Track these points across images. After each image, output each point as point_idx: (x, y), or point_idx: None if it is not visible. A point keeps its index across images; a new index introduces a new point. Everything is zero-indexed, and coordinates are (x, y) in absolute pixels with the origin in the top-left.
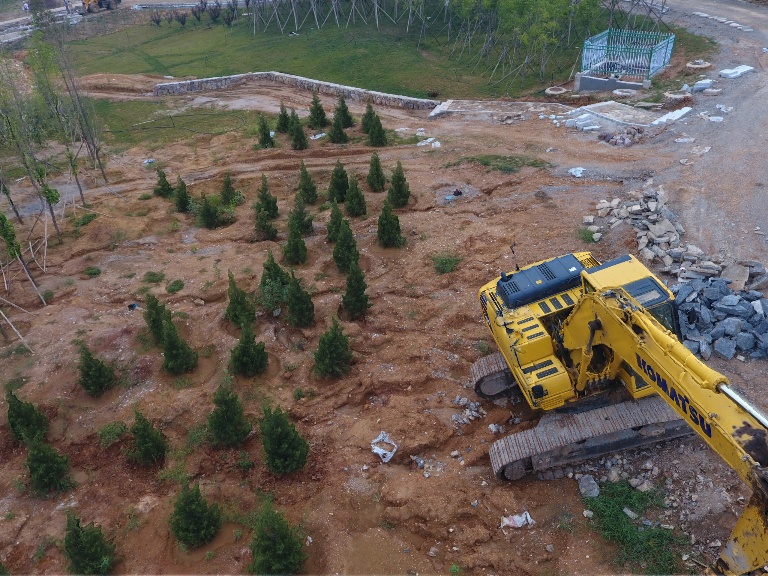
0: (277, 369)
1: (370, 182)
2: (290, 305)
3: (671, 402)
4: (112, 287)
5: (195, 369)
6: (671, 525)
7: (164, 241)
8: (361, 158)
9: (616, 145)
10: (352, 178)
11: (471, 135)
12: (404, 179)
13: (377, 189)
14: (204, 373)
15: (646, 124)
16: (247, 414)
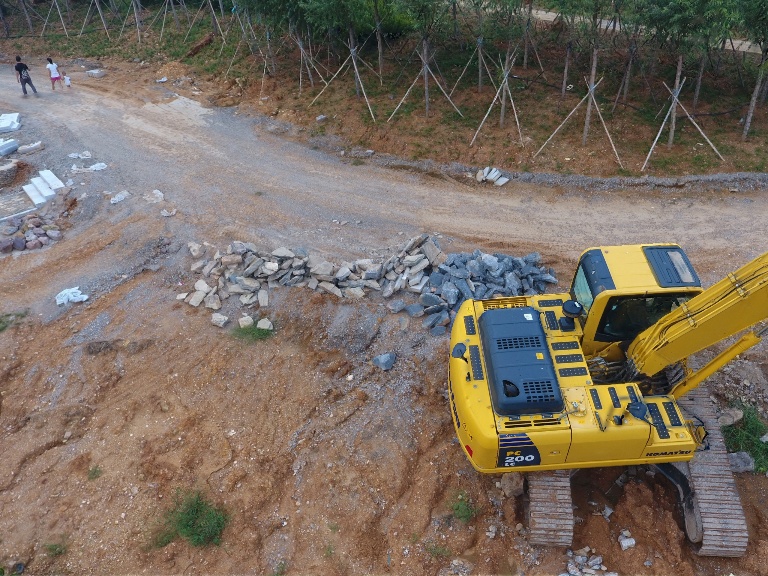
0: None
1: None
2: None
3: None
4: None
5: None
6: None
7: None
8: None
9: (45, 246)
10: None
11: None
12: None
13: None
14: None
15: (27, 209)
16: None
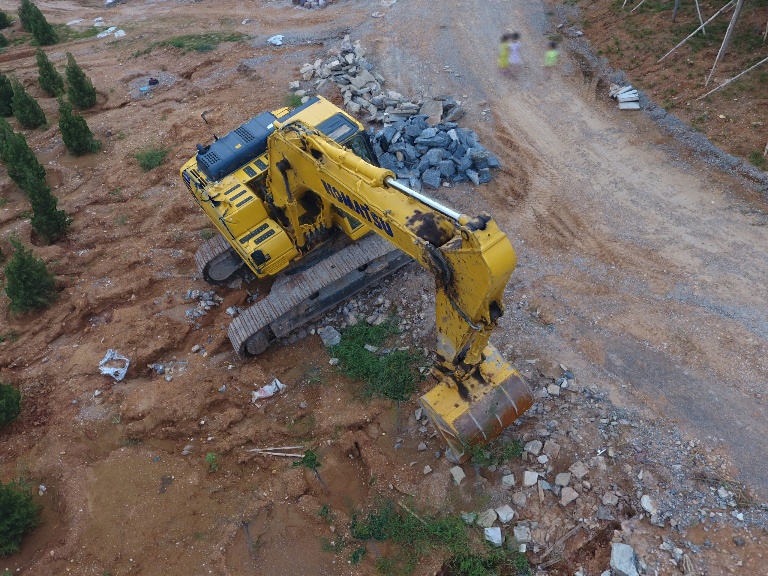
0: None
1: (44, 86)
2: None
3: (359, 217)
4: None
5: None
6: (407, 346)
7: None
8: (29, 61)
9: (311, 8)
10: (13, 81)
11: (158, 18)
12: (82, 74)
13: (55, 93)
14: None
15: None
16: None
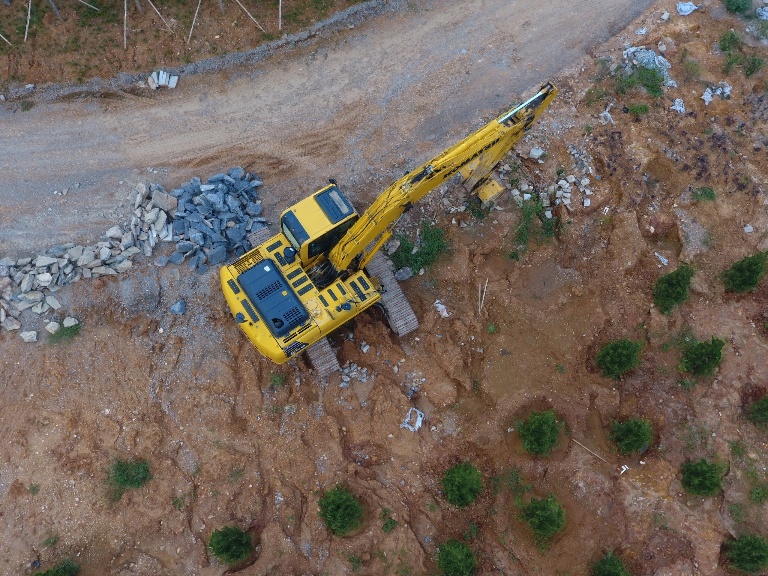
0: None
1: None
2: None
3: None
4: None
5: None
6: (417, 230)
7: None
8: None
9: None
10: None
11: None
12: None
13: None
14: None
15: None
16: (426, 568)
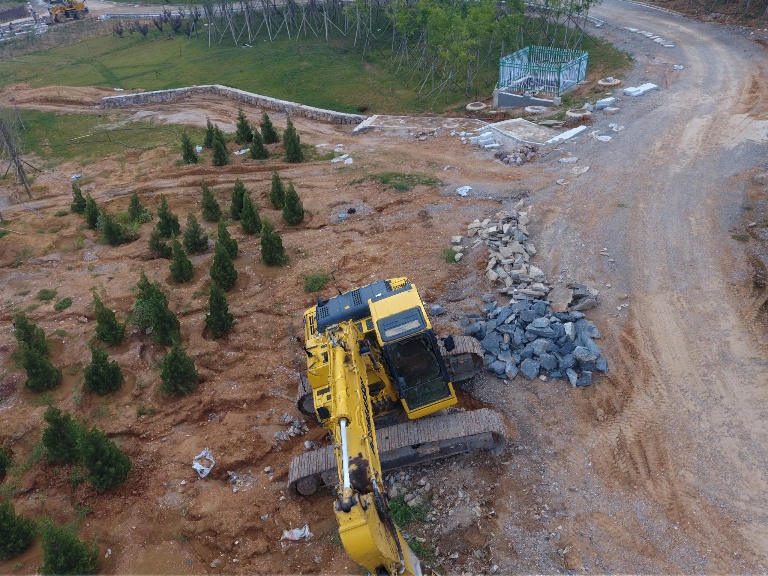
0: (132, 387)
1: (273, 200)
2: (154, 324)
3: None
4: (5, 305)
5: (58, 386)
6: (424, 538)
7: (66, 258)
8: None
9: (508, 164)
10: (245, 197)
11: (383, 152)
12: (297, 198)
13: (279, 206)
14: (66, 390)
15: (542, 142)
16: None
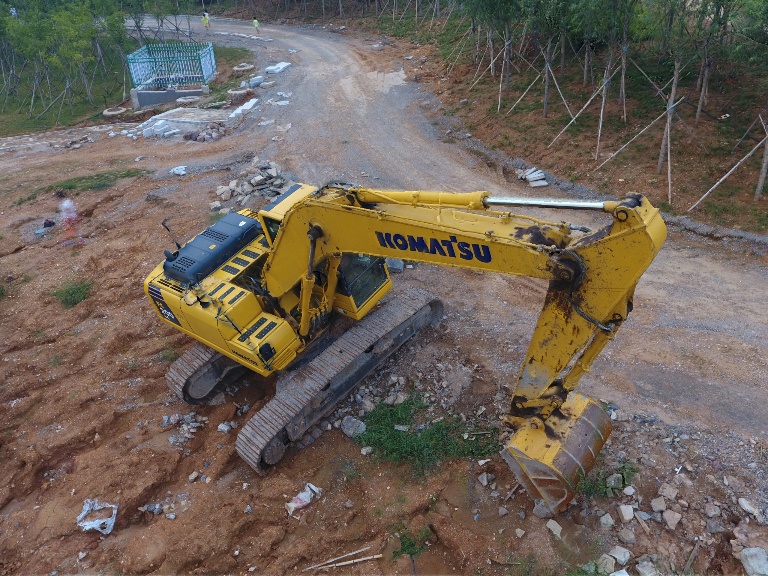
0: None
1: None
2: None
3: (433, 258)
4: None
5: None
6: (440, 417)
7: None
8: None
9: (205, 141)
10: None
11: (35, 167)
12: None
13: None
14: None
15: (224, 119)
16: None
